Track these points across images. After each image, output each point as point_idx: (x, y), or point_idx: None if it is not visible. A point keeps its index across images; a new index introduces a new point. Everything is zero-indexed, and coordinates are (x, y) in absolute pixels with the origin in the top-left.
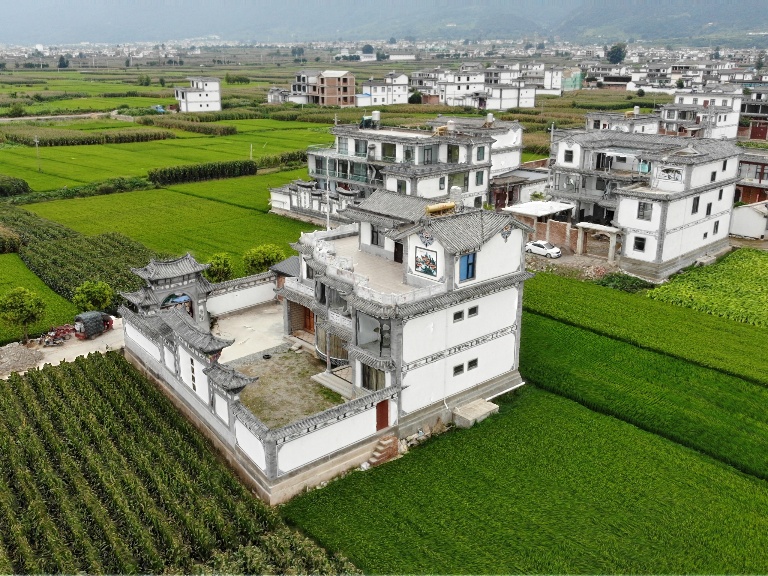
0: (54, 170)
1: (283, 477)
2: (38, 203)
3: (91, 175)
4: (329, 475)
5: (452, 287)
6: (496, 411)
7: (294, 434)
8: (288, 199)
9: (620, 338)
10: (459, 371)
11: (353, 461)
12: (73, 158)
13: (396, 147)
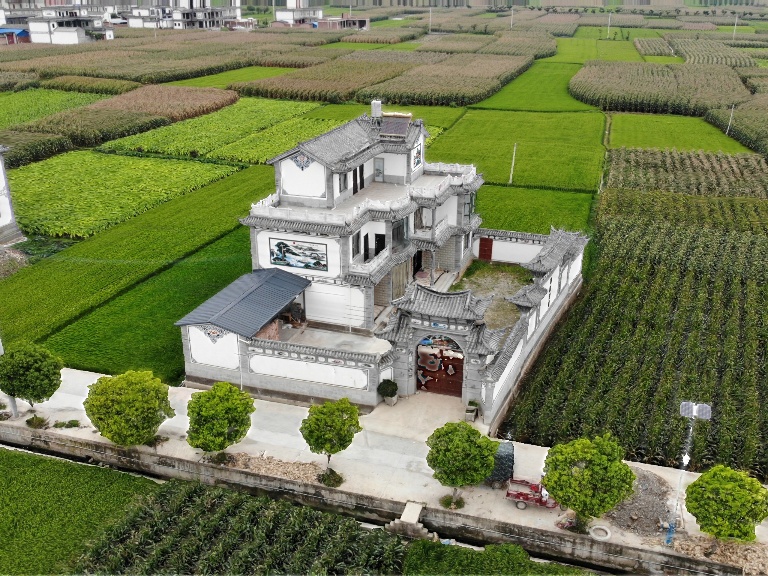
0: None
1: None
2: None
3: None
4: None
5: None
6: None
7: None
8: None
9: (222, 235)
10: None
11: None
12: None
13: None
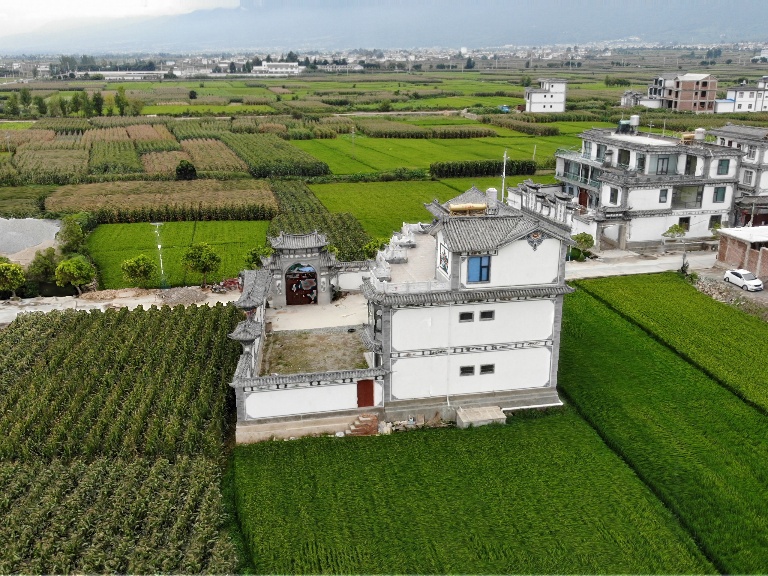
0: (365, 158)
1: (251, 422)
2: (327, 184)
3: (388, 164)
4: (299, 433)
5: (457, 286)
6: (502, 421)
7: (263, 387)
8: (519, 199)
9: (728, 385)
10: (469, 372)
11: (327, 427)
12: (391, 149)
13: (630, 154)
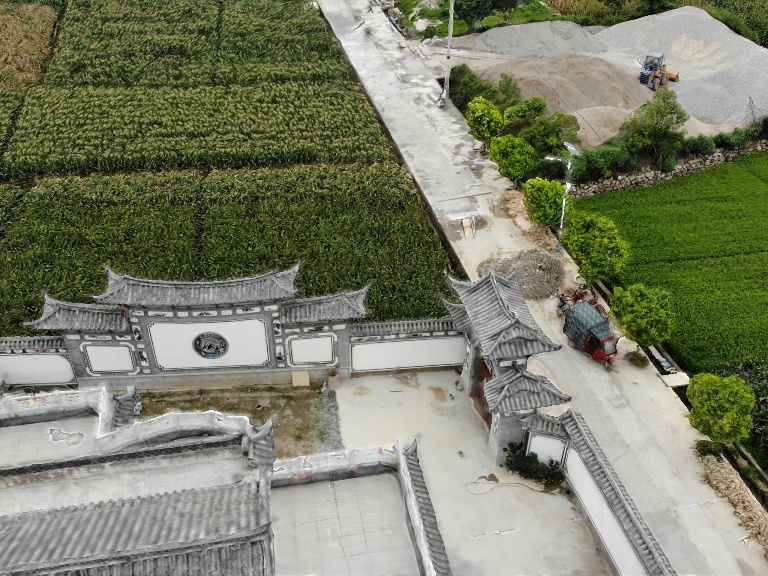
0: None
1: None
2: None
3: None
4: None
5: None
6: None
7: None
8: None
9: None
10: None
11: None
12: None
13: None
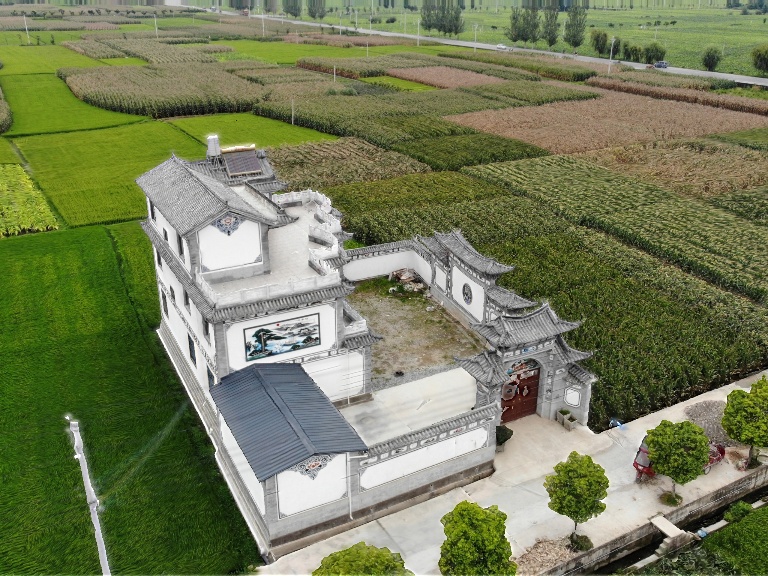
0: None
1: None
2: None
3: None
4: None
5: None
6: None
7: None
8: None
9: None
10: None
11: None
12: None
13: None
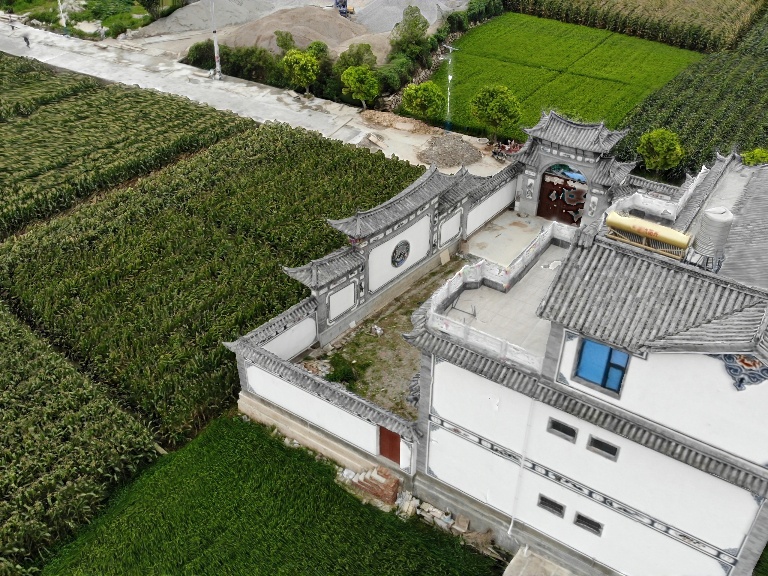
0: None
1: (255, 396)
2: None
3: None
4: (304, 441)
5: (553, 374)
6: None
7: None
8: None
9: None
10: (555, 509)
11: (336, 455)
12: None
13: None
